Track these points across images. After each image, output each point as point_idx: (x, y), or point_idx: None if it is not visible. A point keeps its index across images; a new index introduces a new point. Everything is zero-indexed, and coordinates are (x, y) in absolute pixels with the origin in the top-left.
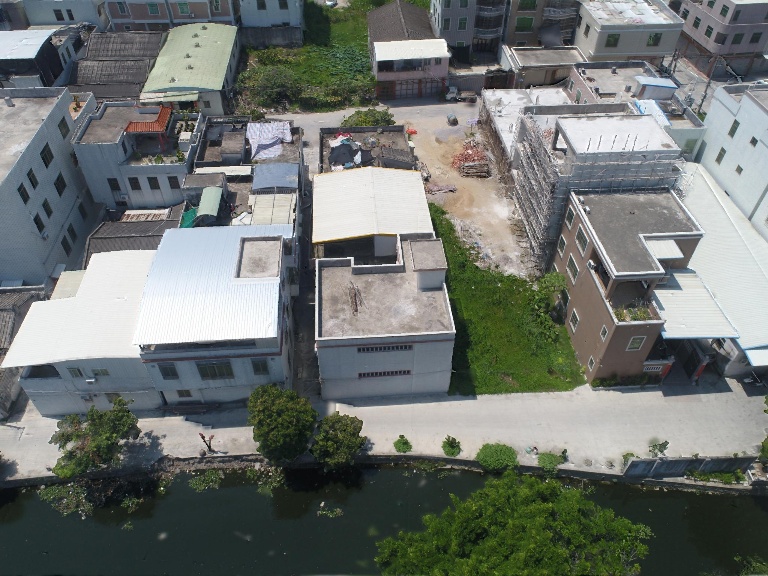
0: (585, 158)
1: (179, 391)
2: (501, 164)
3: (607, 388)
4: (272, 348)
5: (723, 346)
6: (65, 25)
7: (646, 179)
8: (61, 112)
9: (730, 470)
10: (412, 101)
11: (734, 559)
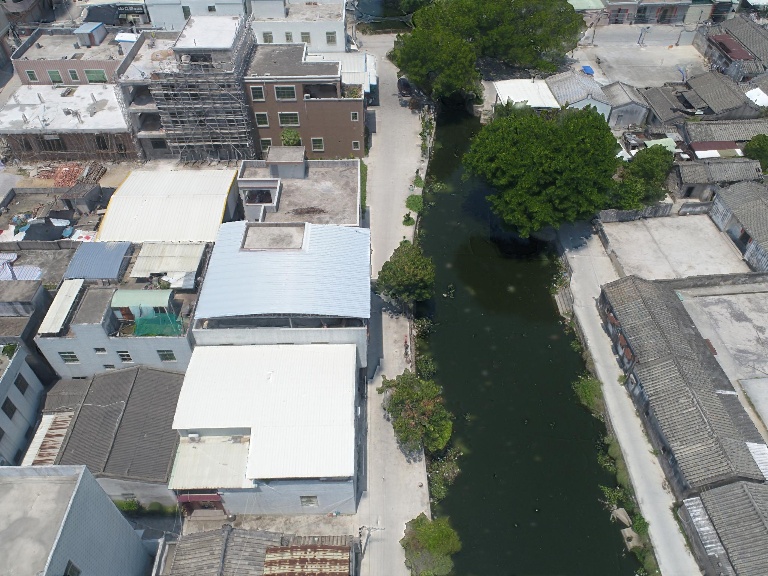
0: (237, 46)
1: None
2: (104, 151)
3: (368, 151)
4: None
5: None
6: None
7: (249, 44)
8: None
9: None
10: None
11: (471, 140)
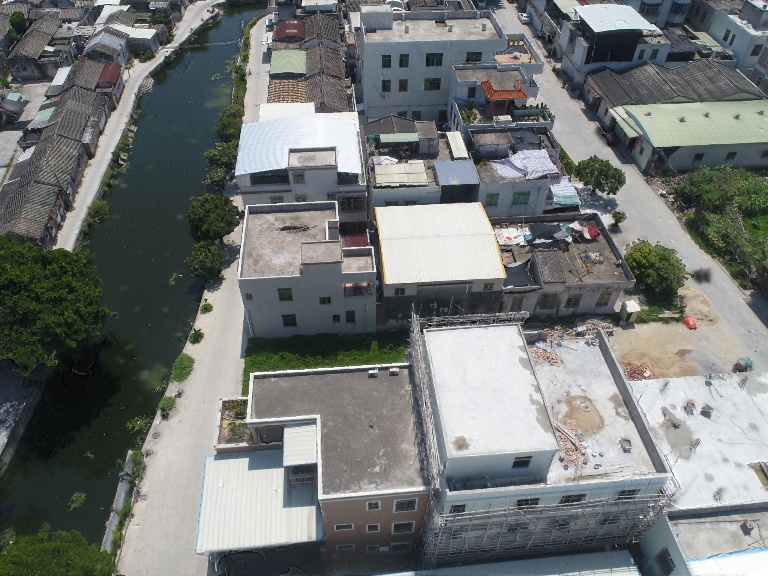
0: None
1: None
2: None
3: None
4: None
5: None
6: (720, 45)
7: None
8: (481, 48)
9: None
10: None
11: None
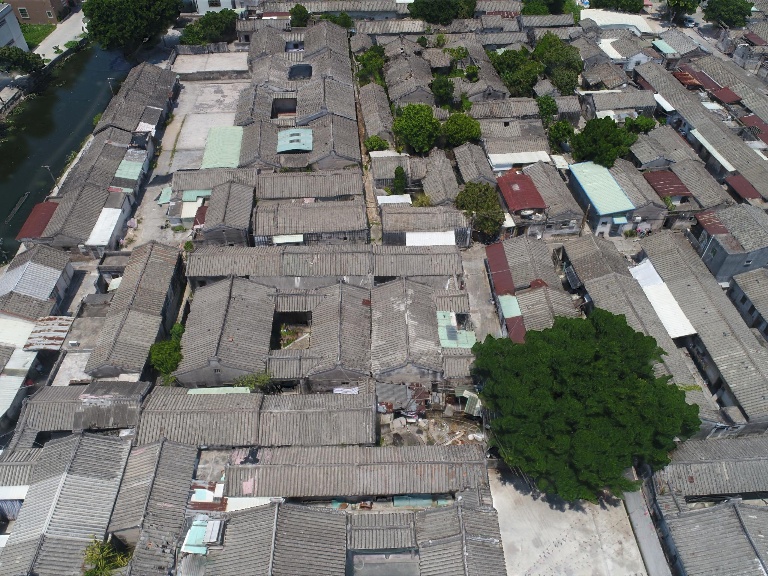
0: None
1: None
2: None
3: (63, 20)
4: None
5: None
6: None
7: None
8: None
9: None
10: None
11: None
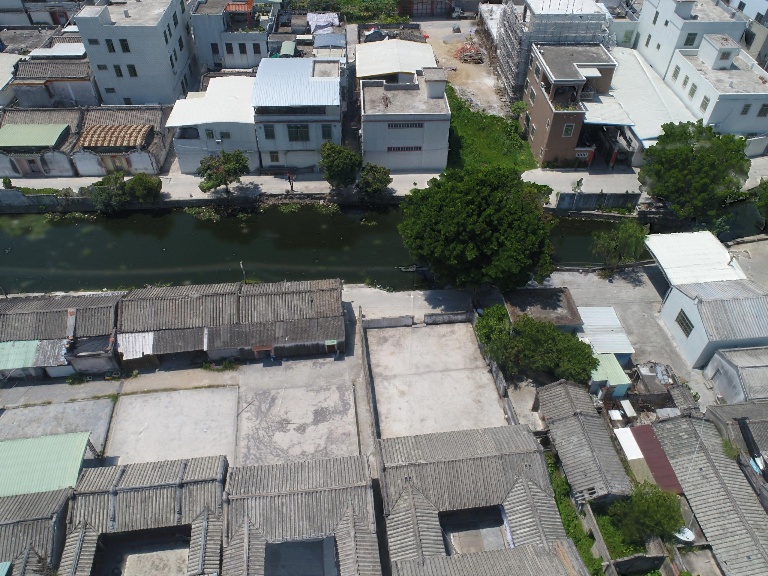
0: (541, 17)
1: (271, 156)
2: (491, 53)
3: (552, 169)
4: (335, 116)
5: (631, 144)
6: None
7: (583, 36)
8: None
9: (625, 207)
10: (426, 18)
11: None
